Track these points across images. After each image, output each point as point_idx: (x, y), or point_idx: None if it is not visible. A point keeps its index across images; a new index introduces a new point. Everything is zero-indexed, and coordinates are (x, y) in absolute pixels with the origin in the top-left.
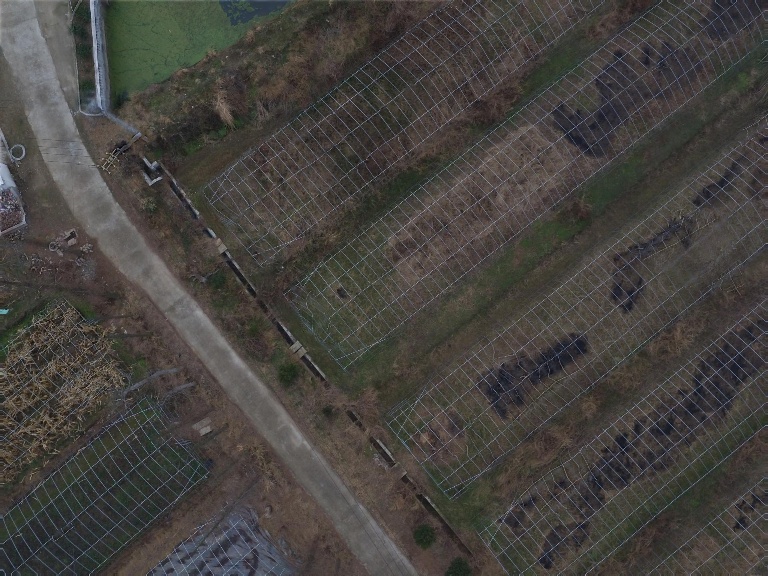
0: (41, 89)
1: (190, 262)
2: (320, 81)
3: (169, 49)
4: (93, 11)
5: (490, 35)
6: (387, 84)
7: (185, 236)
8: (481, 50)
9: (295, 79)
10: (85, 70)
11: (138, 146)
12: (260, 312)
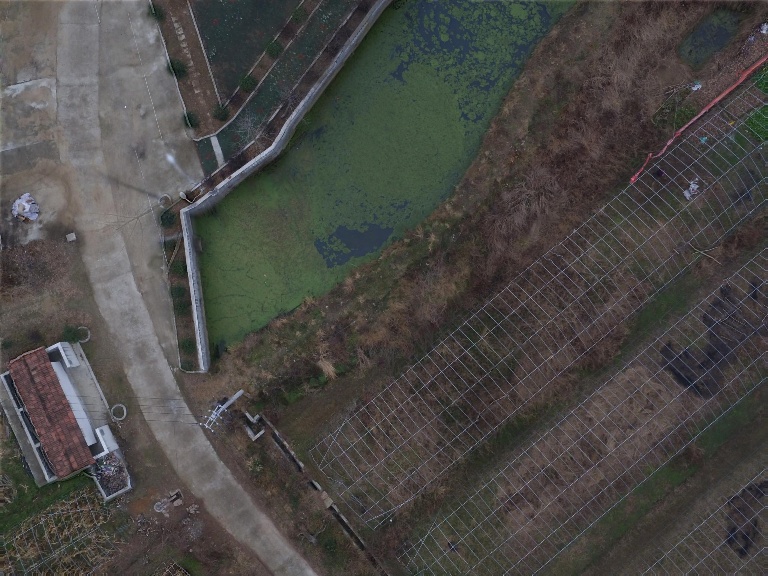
0: (139, 346)
1: (297, 519)
2: (421, 326)
3: (265, 294)
4: (189, 264)
5: (599, 289)
6: (495, 342)
7: (291, 491)
8: (590, 304)
9: (396, 326)
10: (183, 325)
11: (240, 402)
12: (369, 565)
